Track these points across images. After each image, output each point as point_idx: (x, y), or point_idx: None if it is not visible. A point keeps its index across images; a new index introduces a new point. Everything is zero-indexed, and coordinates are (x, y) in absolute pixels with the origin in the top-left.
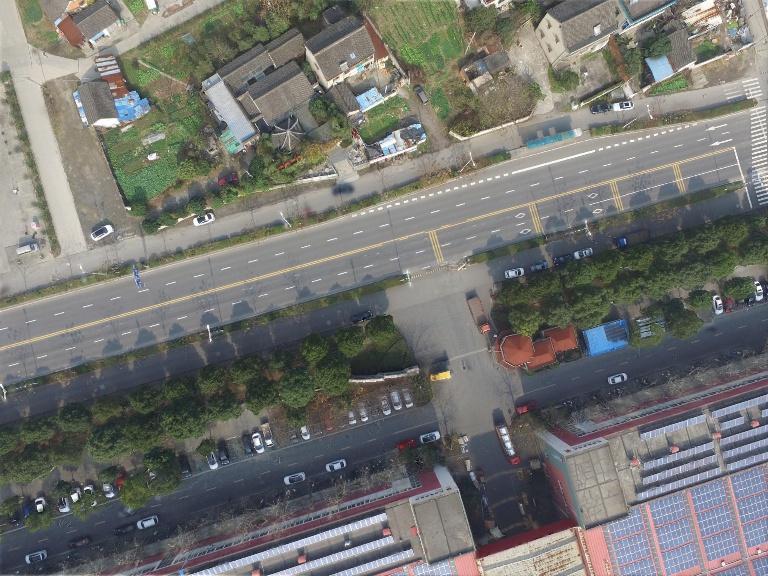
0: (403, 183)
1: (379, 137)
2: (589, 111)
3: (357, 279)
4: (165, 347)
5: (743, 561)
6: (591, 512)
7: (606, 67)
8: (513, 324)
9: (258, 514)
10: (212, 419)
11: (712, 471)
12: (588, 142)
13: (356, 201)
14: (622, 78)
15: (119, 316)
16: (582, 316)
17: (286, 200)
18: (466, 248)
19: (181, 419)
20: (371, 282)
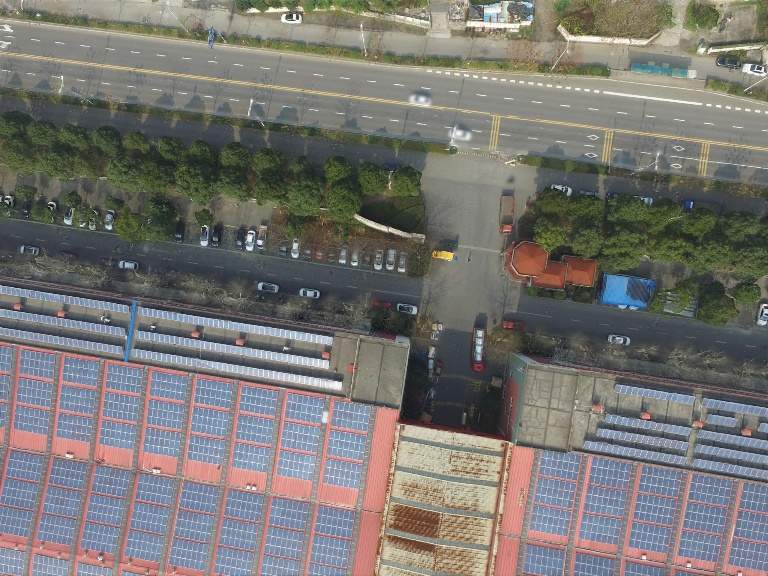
0: (490, 58)
1: (486, 4)
2: (714, 62)
3: (405, 132)
4: (209, 119)
5: (667, 566)
6: (529, 431)
7: (754, 22)
8: (536, 232)
9: (222, 299)
10: (219, 188)
11: (676, 457)
12: (699, 93)
13: (437, 57)
14: (767, 38)
15: (183, 75)
16: (610, 254)
17: (373, 31)
18: (523, 146)
19: (193, 173)
20: (417, 140)
